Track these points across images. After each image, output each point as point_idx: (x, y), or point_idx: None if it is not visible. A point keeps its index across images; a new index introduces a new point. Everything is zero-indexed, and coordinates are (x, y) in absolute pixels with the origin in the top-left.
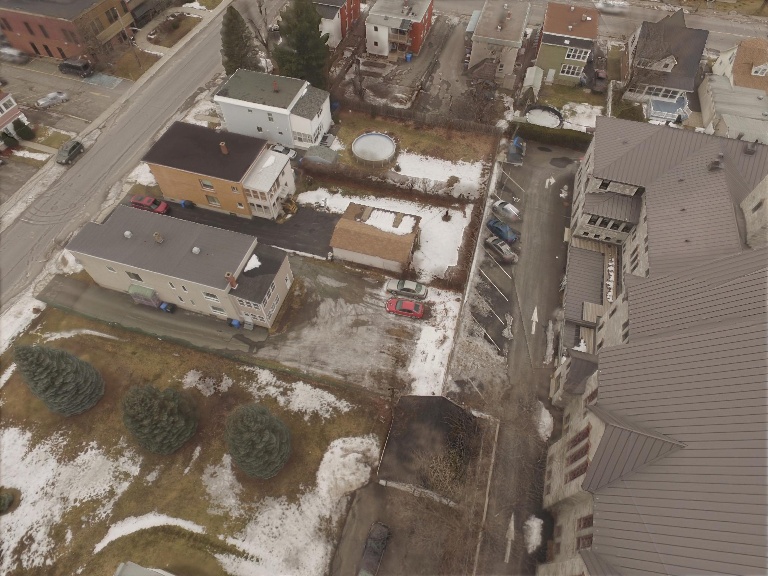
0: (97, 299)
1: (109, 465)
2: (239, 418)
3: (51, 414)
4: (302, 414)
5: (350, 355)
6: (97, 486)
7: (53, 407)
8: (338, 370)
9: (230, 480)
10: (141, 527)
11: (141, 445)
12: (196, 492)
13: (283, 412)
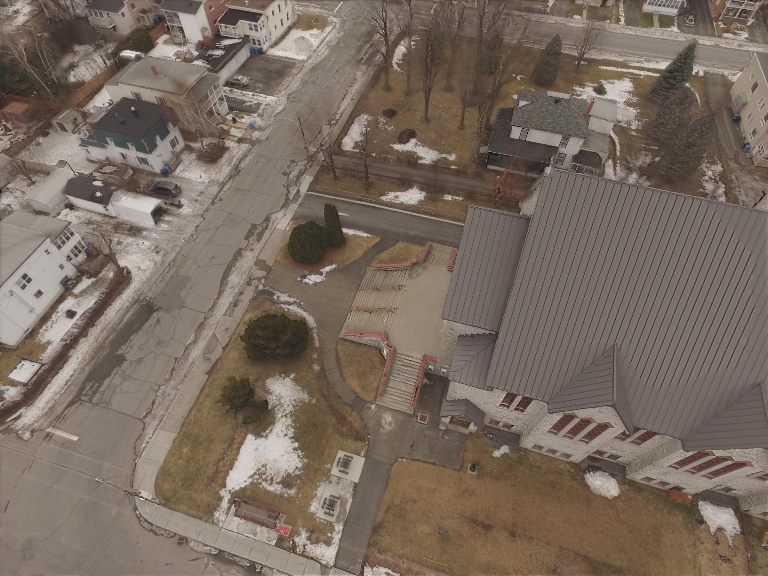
0: (720, 92)
1: (632, 118)
2: (710, 115)
3: (646, 93)
4: (703, 188)
5: (762, 208)
6: (620, 116)
7: (655, 85)
8: (746, 202)
9: (647, 162)
10: (610, 133)
11: (651, 122)
12: (635, 150)
13: (699, 179)
